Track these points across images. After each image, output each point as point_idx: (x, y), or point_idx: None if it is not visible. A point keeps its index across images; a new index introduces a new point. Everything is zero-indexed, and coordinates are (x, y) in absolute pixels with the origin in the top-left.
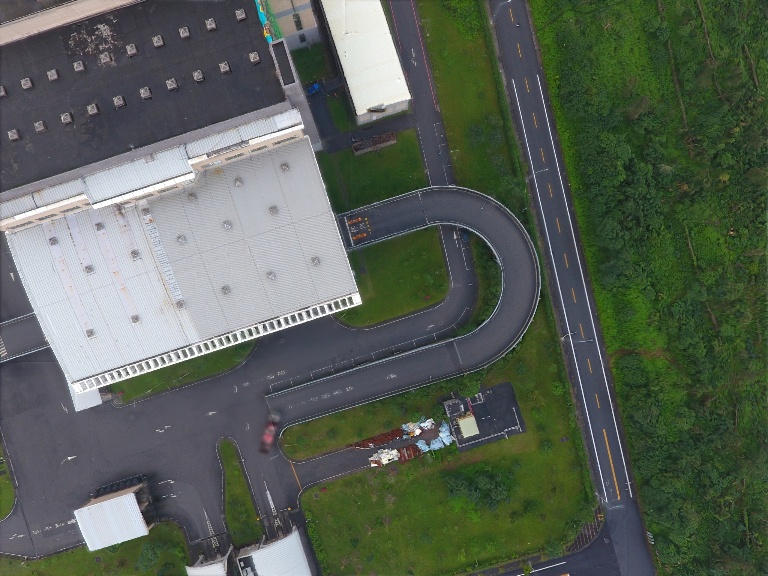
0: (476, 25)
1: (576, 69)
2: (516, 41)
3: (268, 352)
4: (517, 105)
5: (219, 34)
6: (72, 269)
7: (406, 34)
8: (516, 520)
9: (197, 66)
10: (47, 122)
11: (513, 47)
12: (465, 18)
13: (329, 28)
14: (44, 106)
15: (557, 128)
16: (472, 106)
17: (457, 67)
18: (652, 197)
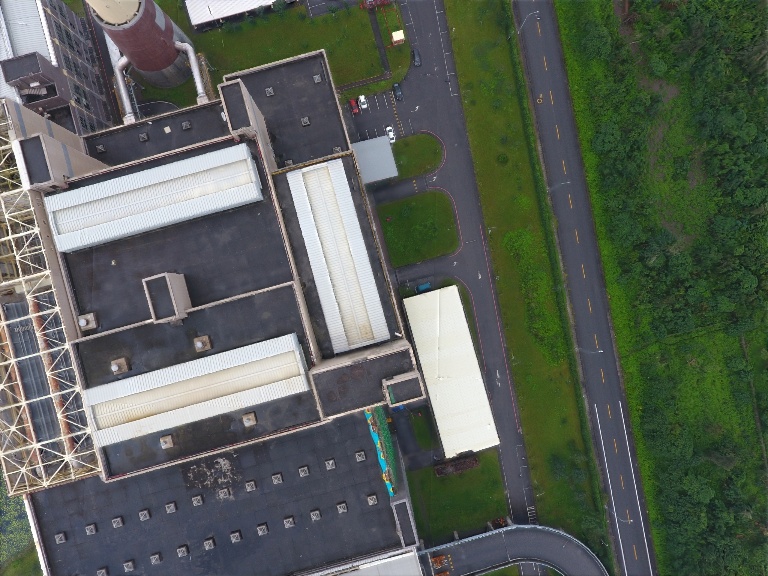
0: (562, 353)
1: (660, 403)
2: (600, 367)
3: None
4: (598, 430)
5: (338, 473)
6: None
7: (491, 355)
8: None
9: (315, 504)
10: (163, 553)
11: (597, 373)
12: (551, 346)
13: (422, 370)
14: (160, 537)
15: (637, 456)
16: (555, 432)
17: (541, 392)
18: (733, 544)
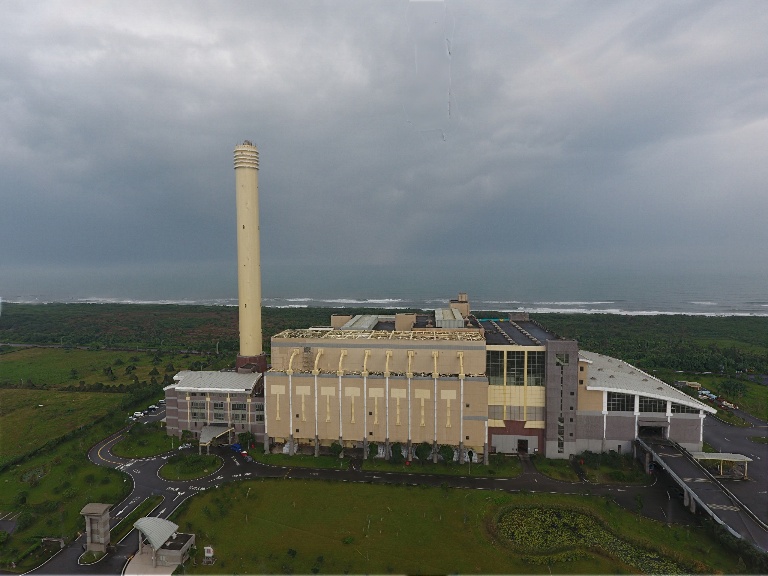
0: None
1: None
2: None
3: None
4: None
5: None
6: None
7: None
8: (750, 387)
9: None
10: None
11: None
12: None
13: None
14: None
15: None
16: None
17: None
18: None
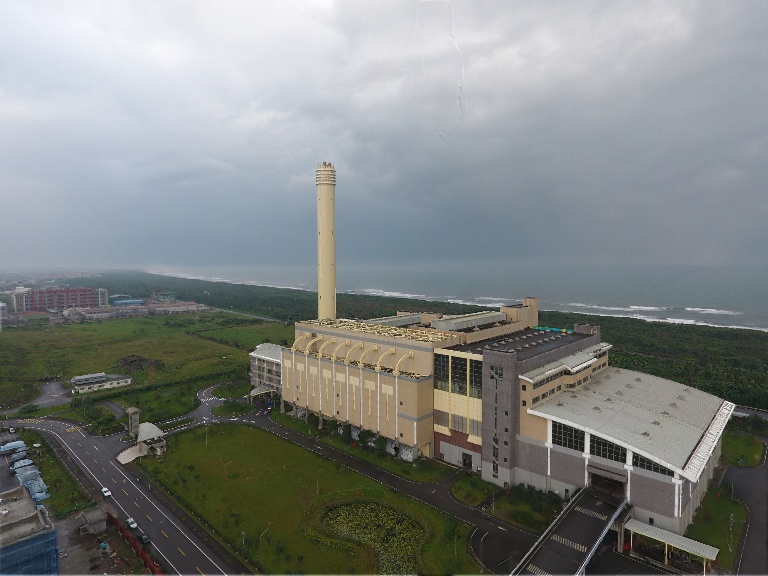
0: None
1: None
2: None
3: (745, 494)
4: None
5: None
6: (587, 412)
7: None
8: None
9: None
10: None
11: None
12: None
13: None
14: None
15: None
16: None
17: None
18: None
